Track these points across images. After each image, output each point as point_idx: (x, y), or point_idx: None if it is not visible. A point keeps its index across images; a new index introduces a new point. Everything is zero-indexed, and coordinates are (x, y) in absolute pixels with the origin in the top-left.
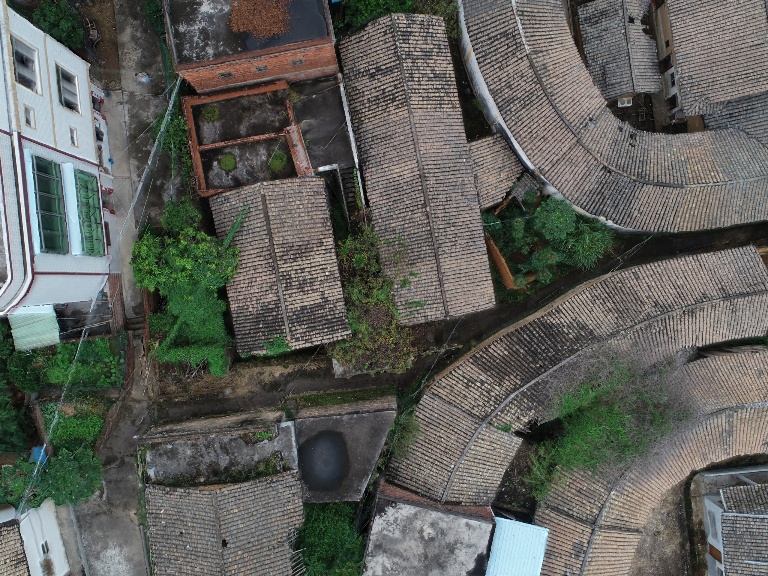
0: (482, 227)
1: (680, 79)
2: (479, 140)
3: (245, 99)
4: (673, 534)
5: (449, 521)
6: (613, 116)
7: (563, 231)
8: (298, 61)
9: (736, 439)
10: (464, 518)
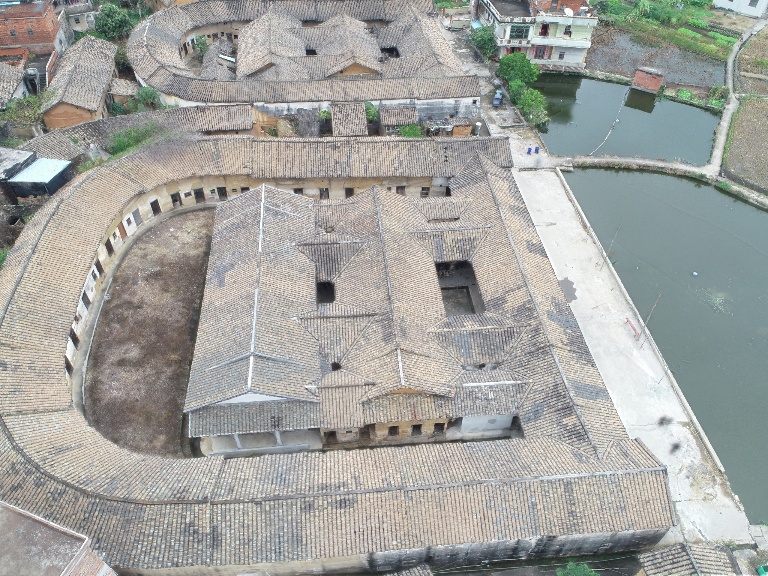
0: (103, 91)
1: (237, 74)
2: (122, 79)
3: (7, 57)
4: (199, 245)
5: (8, 151)
6: (193, 74)
7: (148, 96)
8: (30, 32)
9: (224, 162)
10: (18, 150)
